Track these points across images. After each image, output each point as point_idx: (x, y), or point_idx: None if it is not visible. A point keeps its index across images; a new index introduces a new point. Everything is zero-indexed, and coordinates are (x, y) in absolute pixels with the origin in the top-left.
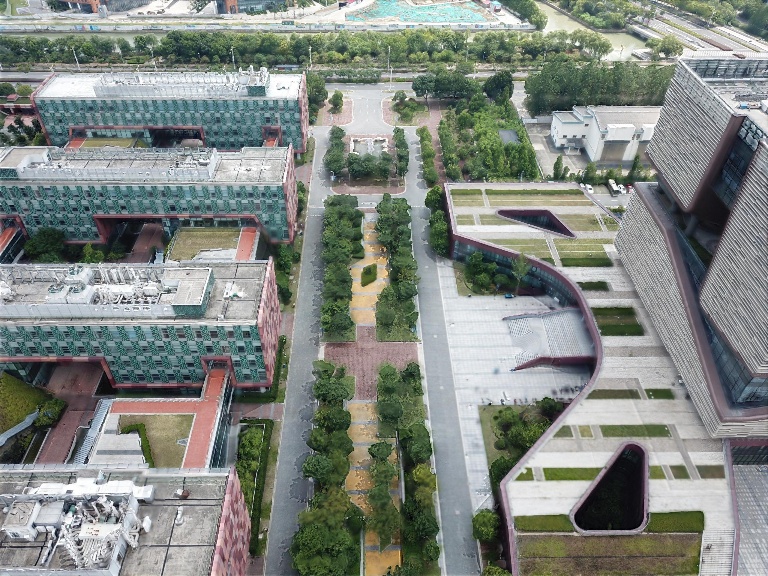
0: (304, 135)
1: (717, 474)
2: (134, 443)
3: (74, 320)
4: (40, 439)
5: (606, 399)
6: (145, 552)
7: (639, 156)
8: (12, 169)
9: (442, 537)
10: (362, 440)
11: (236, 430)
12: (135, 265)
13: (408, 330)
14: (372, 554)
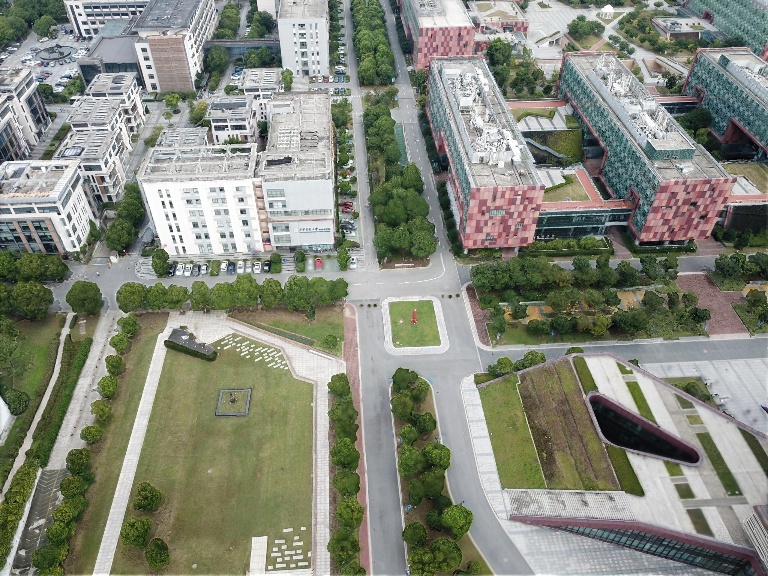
0: None
1: (699, 527)
2: (559, 182)
3: (617, 118)
4: (553, 166)
5: (748, 445)
6: (488, 169)
7: None
8: (728, 60)
9: (563, 347)
10: (622, 300)
11: (597, 236)
12: (681, 128)
13: (761, 325)
14: (537, 309)
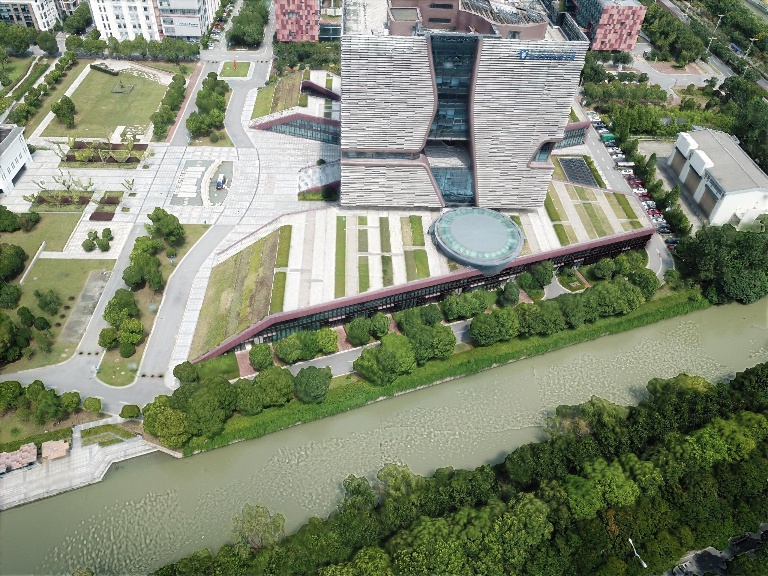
0: (599, 38)
1: None
2: None
3: None
4: None
5: None
6: None
7: (653, 154)
8: None
9: None
10: None
11: None
12: None
13: None
14: None
